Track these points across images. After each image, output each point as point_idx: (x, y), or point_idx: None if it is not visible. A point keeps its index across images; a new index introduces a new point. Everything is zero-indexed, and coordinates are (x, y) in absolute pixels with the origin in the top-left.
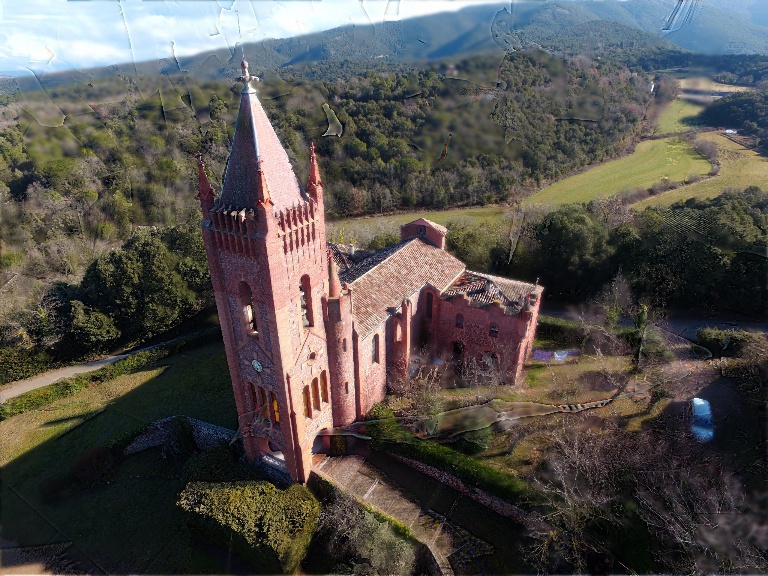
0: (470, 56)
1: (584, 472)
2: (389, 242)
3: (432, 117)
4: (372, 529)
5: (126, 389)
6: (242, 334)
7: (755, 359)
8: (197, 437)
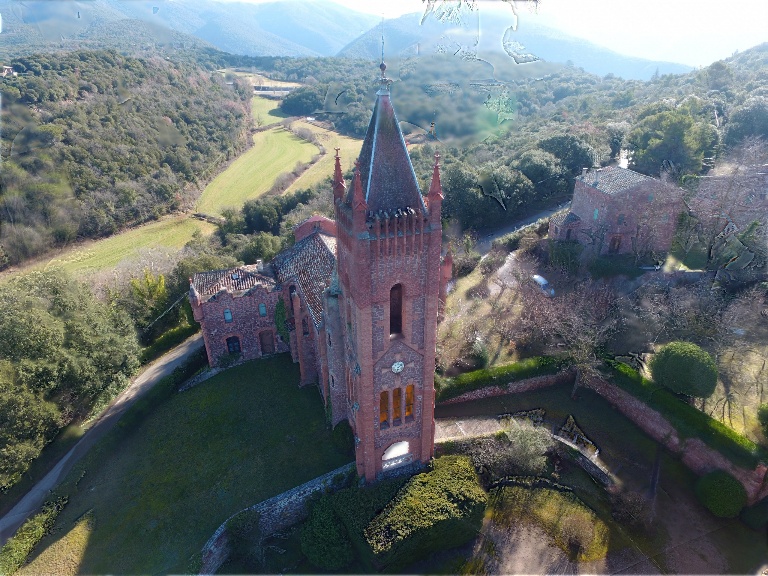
0: (499, 60)
1: (556, 332)
2: (202, 264)
3: (403, 111)
4: (522, 434)
5: (63, 575)
6: (384, 342)
7: (530, 245)
8: (266, 522)
